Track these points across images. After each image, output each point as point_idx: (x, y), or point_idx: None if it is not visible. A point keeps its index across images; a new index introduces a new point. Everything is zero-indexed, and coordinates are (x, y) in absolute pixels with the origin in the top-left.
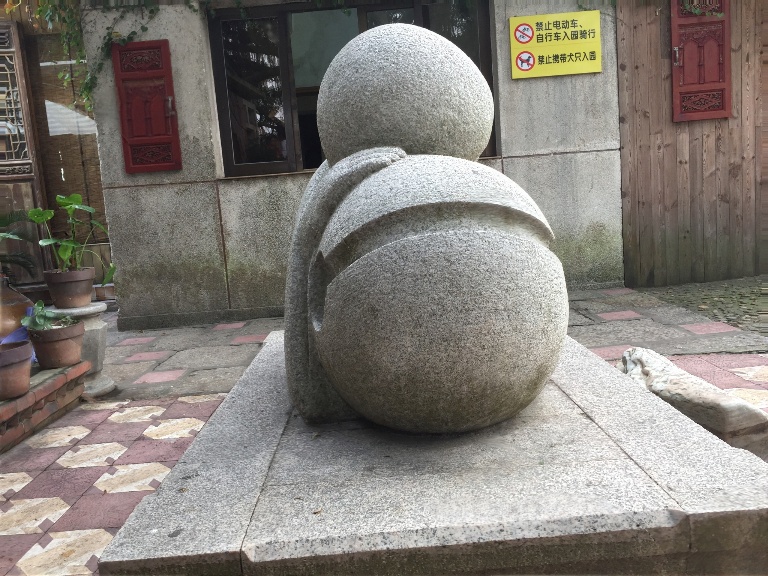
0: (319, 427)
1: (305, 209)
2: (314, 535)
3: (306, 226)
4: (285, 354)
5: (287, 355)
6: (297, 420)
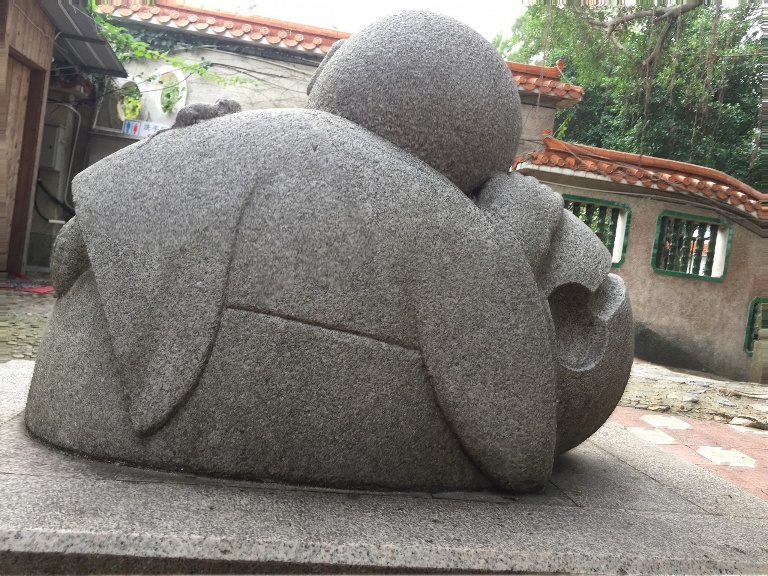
0: (546, 489)
1: (515, 226)
2: (759, 499)
3: (541, 250)
4: (544, 413)
5: (551, 412)
6: (525, 499)
